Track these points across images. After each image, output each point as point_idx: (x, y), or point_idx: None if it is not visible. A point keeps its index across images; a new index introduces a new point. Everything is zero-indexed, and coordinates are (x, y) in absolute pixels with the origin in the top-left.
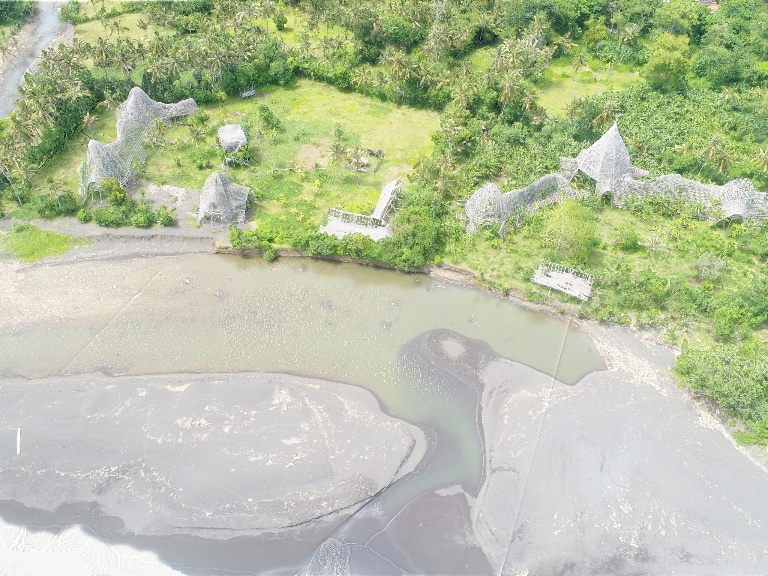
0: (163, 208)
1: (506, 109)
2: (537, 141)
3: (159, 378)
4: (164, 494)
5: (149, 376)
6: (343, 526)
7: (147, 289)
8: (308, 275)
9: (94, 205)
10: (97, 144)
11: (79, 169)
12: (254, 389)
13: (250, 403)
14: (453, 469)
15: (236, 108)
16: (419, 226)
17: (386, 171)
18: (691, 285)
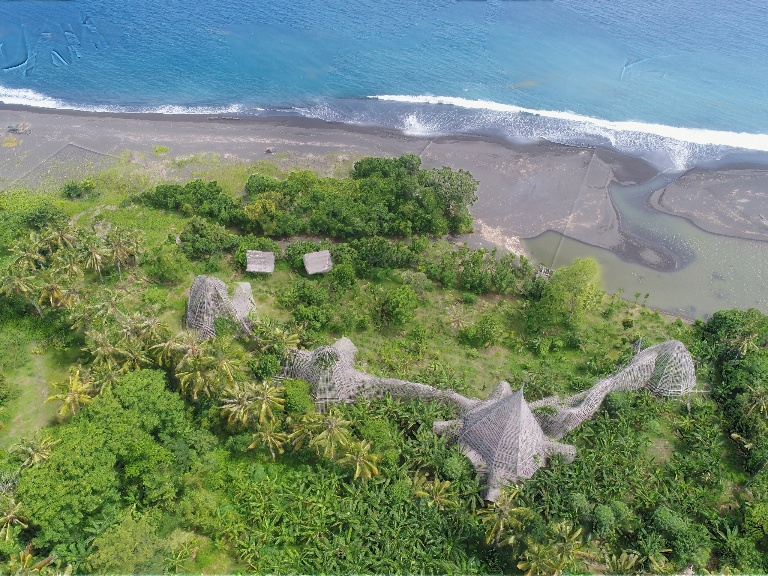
0: None
1: None
2: None
3: None
4: None
5: None
6: None
7: None
8: None
9: None
10: None
11: None
12: None
13: None
14: (629, 193)
15: None
16: None
17: None
18: (425, 294)
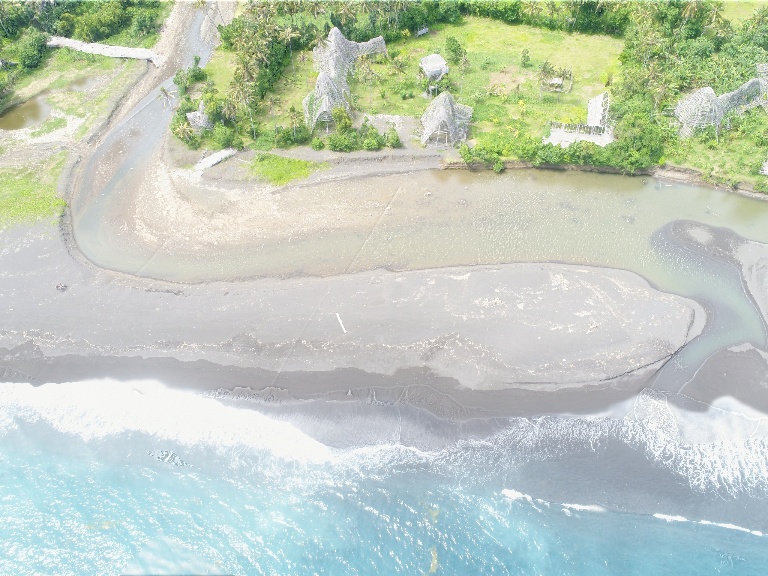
0: (393, 130)
1: (687, 25)
2: (727, 52)
3: (439, 271)
4: (486, 358)
5: (428, 270)
6: (654, 378)
7: (395, 201)
8: (538, 182)
9: (321, 134)
10: (327, 76)
11: (305, 102)
12: (532, 274)
13: (533, 285)
14: (737, 331)
15: (415, 45)
16: (645, 129)
17: (580, 90)
18: None
